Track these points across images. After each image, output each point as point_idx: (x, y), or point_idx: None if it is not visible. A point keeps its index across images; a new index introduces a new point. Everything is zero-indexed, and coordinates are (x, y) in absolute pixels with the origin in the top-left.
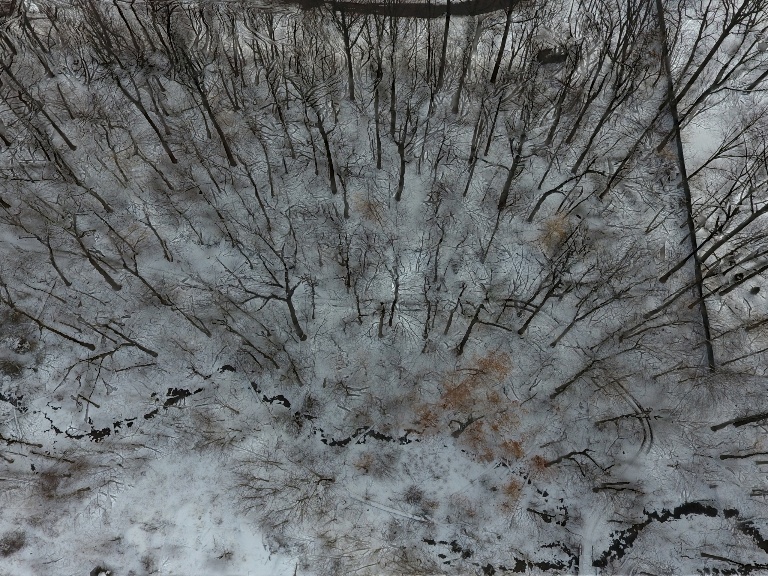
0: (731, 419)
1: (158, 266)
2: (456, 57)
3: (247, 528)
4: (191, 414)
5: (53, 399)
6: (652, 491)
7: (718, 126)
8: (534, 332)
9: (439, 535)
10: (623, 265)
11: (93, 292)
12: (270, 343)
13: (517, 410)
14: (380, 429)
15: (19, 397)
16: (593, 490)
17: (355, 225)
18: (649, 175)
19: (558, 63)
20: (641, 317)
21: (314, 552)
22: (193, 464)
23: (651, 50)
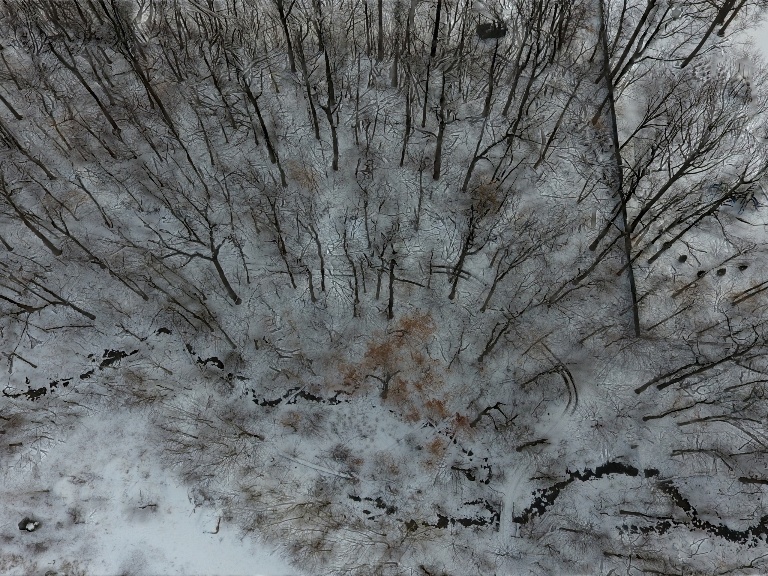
0: (650, 380)
1: (99, 232)
2: (394, 30)
3: (173, 482)
4: (123, 373)
5: None
6: (575, 451)
7: (643, 95)
8: (464, 297)
9: (364, 492)
10: (531, 222)
11: (34, 257)
12: None
13: (444, 371)
14: (310, 390)
15: None
16: (517, 449)
17: (292, 193)
18: (583, 147)
19: (498, 38)
20: (570, 283)
21: (238, 505)
22: (123, 421)
23: (589, 25)
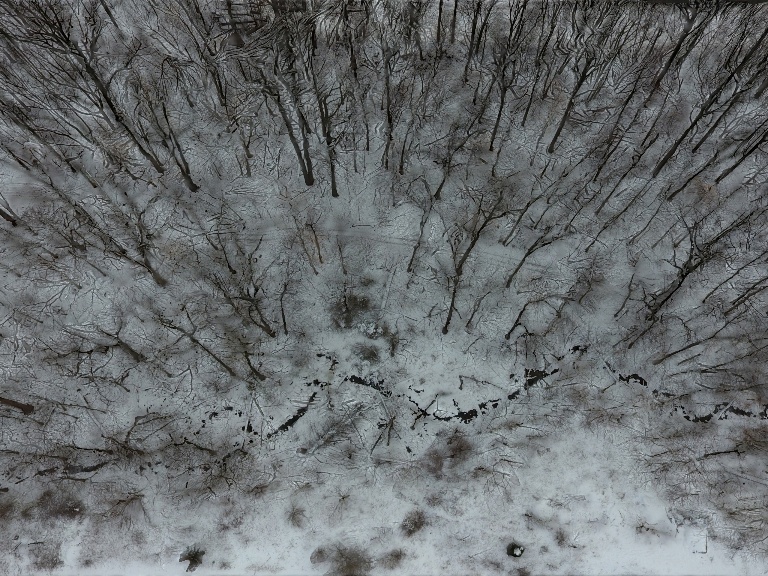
0: None
1: (493, 251)
2: (767, 42)
3: (651, 502)
4: (569, 393)
5: (416, 382)
6: None
7: None
8: None
9: None
10: None
11: (434, 277)
12: (619, 323)
13: None
14: (741, 405)
15: (380, 381)
16: None
17: None
18: None
19: None
20: None
21: (718, 524)
22: (581, 441)
23: None
